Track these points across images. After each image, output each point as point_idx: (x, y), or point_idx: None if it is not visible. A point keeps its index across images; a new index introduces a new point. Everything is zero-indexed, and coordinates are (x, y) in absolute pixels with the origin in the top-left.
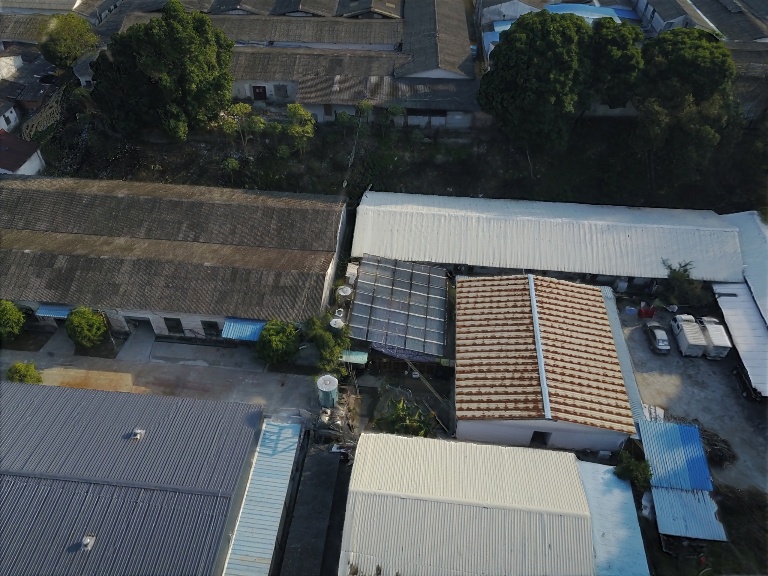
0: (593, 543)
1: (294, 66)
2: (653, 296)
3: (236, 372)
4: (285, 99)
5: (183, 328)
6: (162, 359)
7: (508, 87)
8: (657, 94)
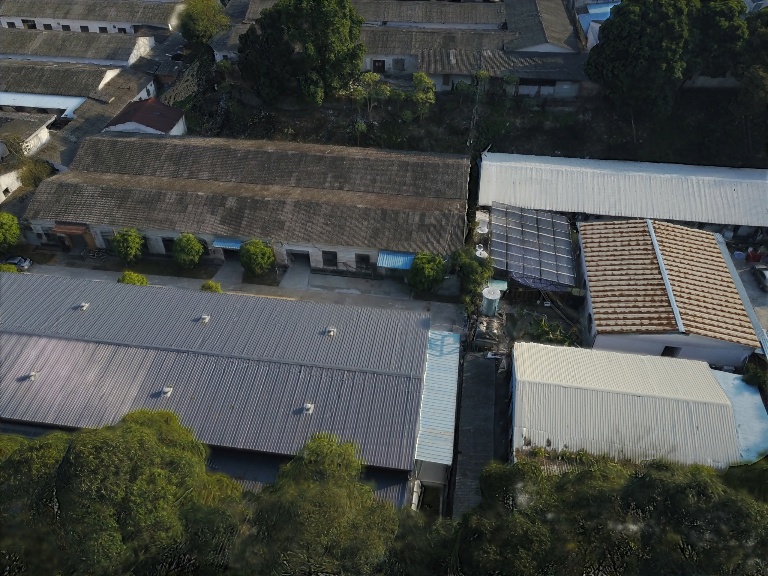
0: (736, 426)
1: (411, 42)
2: (758, 244)
3: (386, 299)
4: (401, 72)
5: (337, 261)
6: (319, 287)
7: (619, 56)
8: (760, 62)
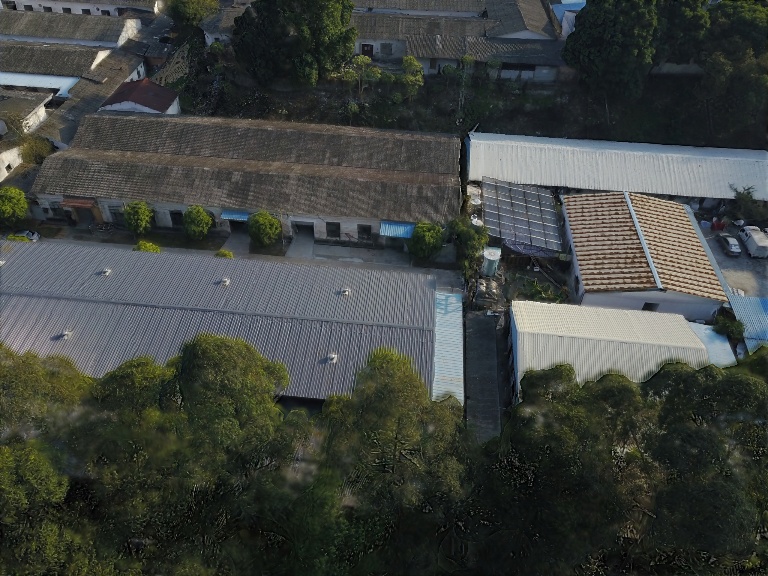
0: None
1: (398, 27)
2: (721, 215)
3: (387, 267)
4: (389, 56)
5: (340, 232)
6: (324, 257)
7: (594, 43)
8: (721, 49)
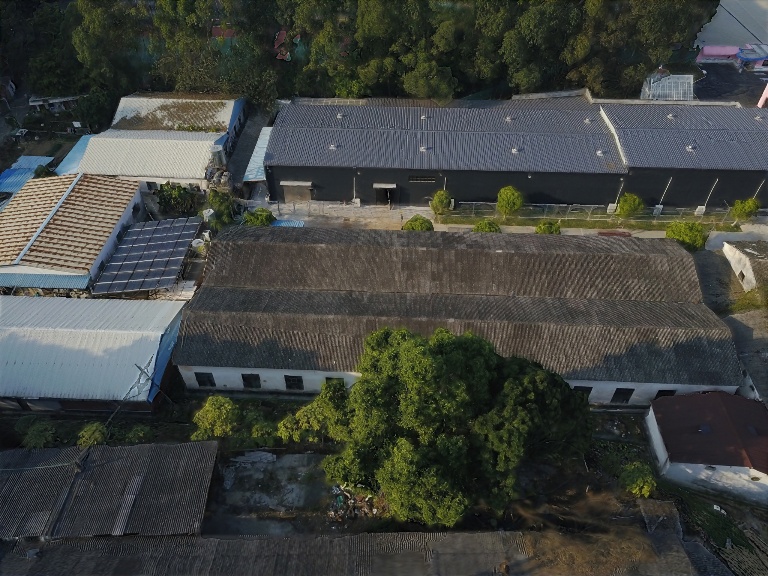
0: None
1: None
2: None
3: None
4: None
5: None
6: None
7: None
8: None
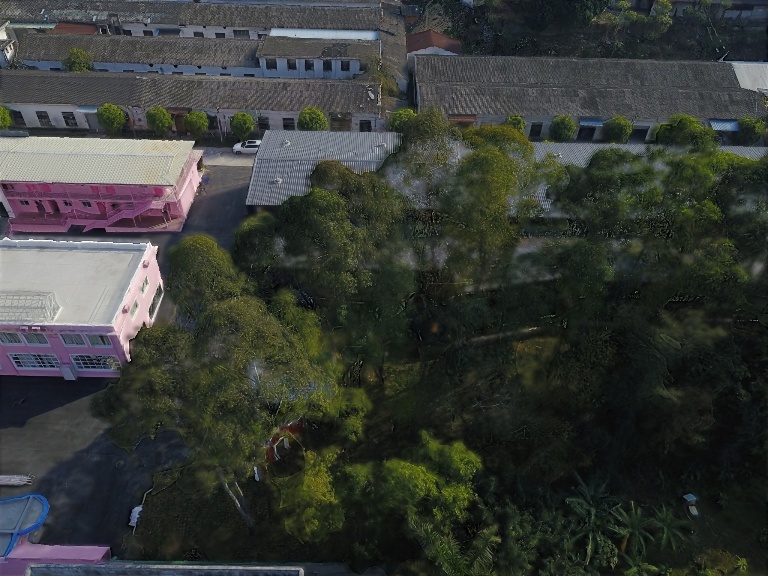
0: None
1: None
2: None
3: None
4: None
5: None
6: None
7: None
8: None
